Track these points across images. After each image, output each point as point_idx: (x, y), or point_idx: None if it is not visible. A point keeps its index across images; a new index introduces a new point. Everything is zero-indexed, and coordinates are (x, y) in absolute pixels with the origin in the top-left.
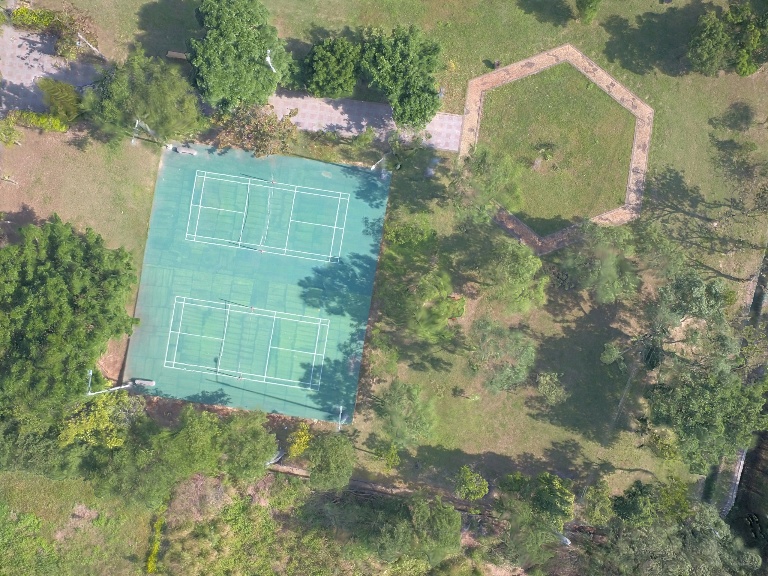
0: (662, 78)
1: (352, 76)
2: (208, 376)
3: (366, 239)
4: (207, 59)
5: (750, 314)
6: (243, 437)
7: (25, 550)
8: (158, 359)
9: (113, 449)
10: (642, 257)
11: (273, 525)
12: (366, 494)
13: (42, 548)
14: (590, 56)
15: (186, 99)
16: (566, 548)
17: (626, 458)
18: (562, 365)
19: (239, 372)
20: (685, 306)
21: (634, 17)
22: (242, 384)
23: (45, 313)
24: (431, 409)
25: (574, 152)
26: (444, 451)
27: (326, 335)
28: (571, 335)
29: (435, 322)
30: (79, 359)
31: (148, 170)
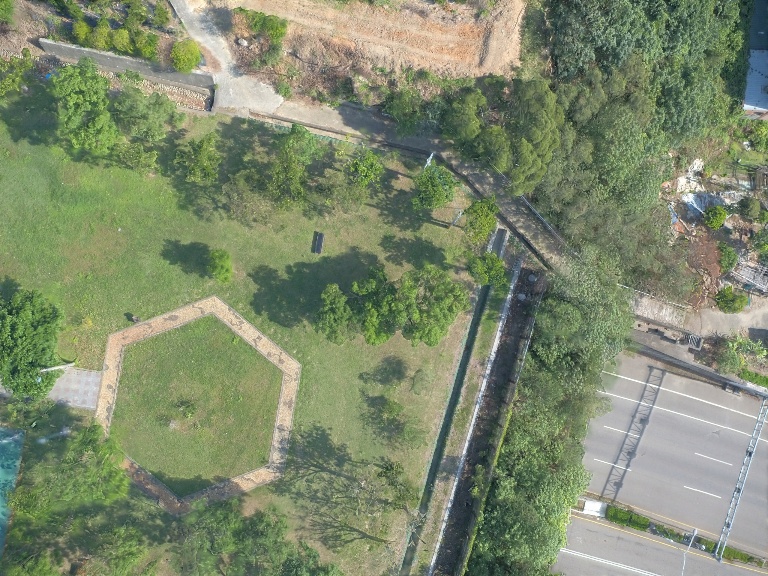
0: (312, 331)
1: None
2: None
3: None
4: None
5: (403, 571)
6: None
7: None
8: None
9: None
10: (243, 549)
11: None
12: None
13: None
14: (237, 308)
15: None
16: None
17: None
18: None
19: None
20: None
21: (284, 267)
22: None
23: None
24: None
25: (217, 409)
26: None
27: None
28: None
29: None
30: None
31: None
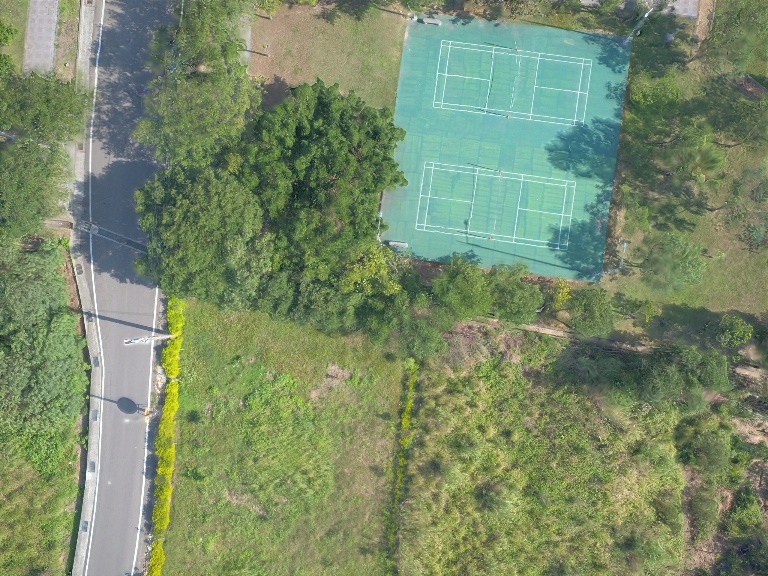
0: None
1: None
2: (459, 238)
3: (609, 103)
4: None
5: None
6: (510, 286)
7: (282, 409)
8: (409, 222)
9: (396, 292)
10: None
11: (523, 381)
12: (613, 351)
13: (297, 407)
14: None
15: None
16: None
17: None
18: None
19: (489, 233)
20: None
21: None
22: (492, 245)
23: (330, 162)
24: None
25: None
26: (688, 309)
27: (573, 196)
28: None
29: (715, 161)
30: (366, 204)
31: (395, 41)
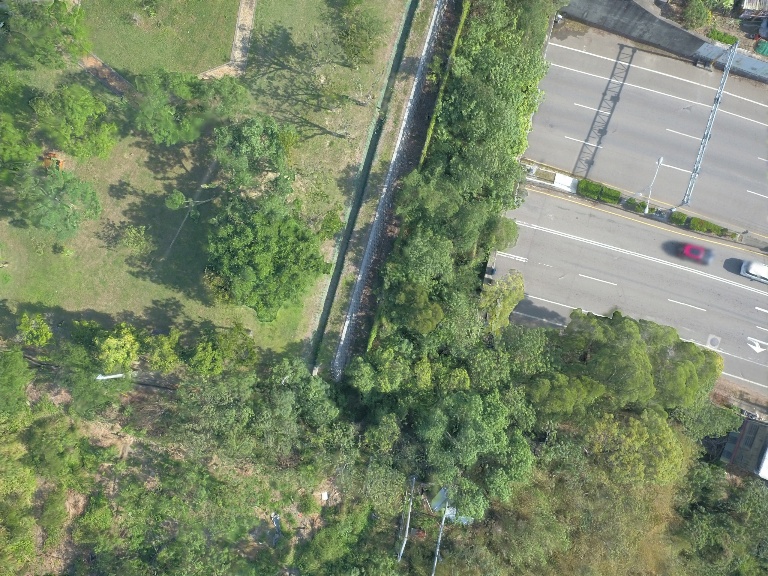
0: None
1: None
2: None
3: None
4: None
5: (364, 174)
6: None
7: None
8: None
9: None
10: (199, 98)
11: None
12: None
13: None
14: None
15: None
16: (154, 403)
17: (227, 316)
18: (162, 222)
19: None
20: (238, 146)
21: None
22: None
23: None
24: (31, 266)
25: (179, 9)
26: (43, 308)
27: None
28: (172, 192)
29: None
30: None
31: None
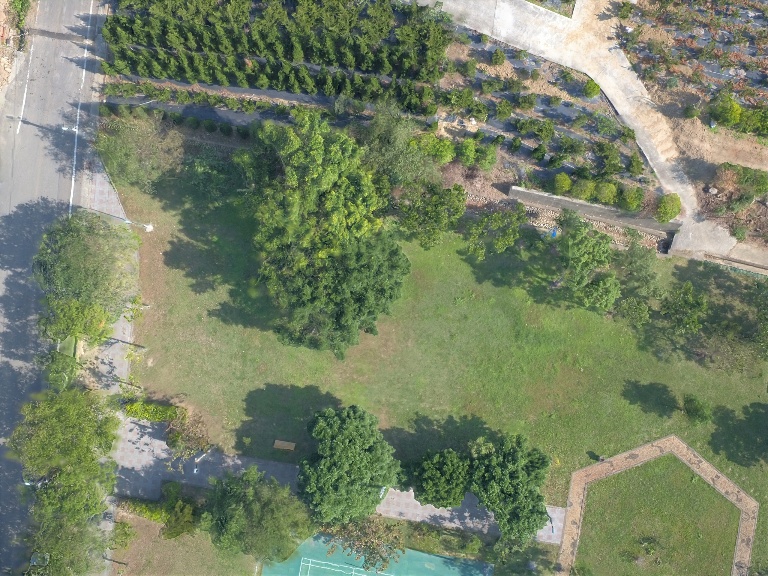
0: None
1: (461, 492)
2: None
3: None
4: (321, 488)
5: None
6: None
7: None
8: None
9: None
10: None
11: None
12: None
13: None
14: (695, 447)
15: (300, 525)
16: None
17: None
18: None
19: None
20: None
21: (741, 407)
22: None
23: None
24: None
25: (677, 546)
26: None
27: None
28: None
29: None
30: None
31: None
